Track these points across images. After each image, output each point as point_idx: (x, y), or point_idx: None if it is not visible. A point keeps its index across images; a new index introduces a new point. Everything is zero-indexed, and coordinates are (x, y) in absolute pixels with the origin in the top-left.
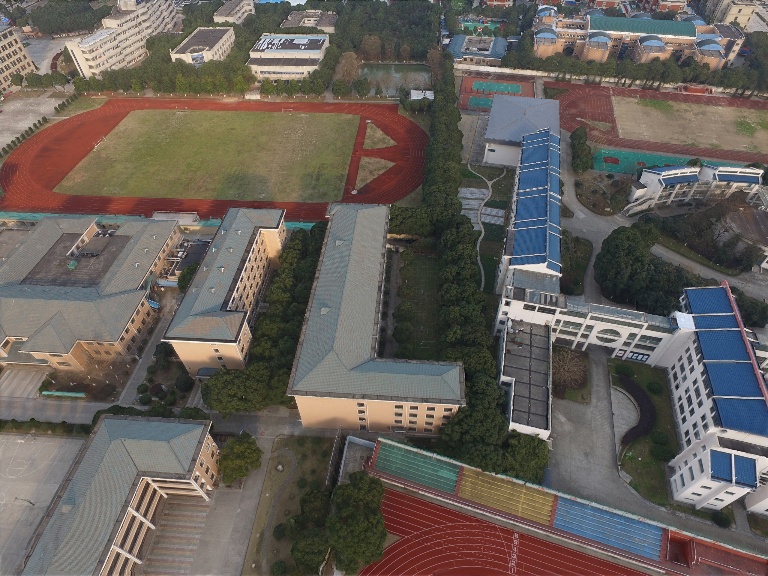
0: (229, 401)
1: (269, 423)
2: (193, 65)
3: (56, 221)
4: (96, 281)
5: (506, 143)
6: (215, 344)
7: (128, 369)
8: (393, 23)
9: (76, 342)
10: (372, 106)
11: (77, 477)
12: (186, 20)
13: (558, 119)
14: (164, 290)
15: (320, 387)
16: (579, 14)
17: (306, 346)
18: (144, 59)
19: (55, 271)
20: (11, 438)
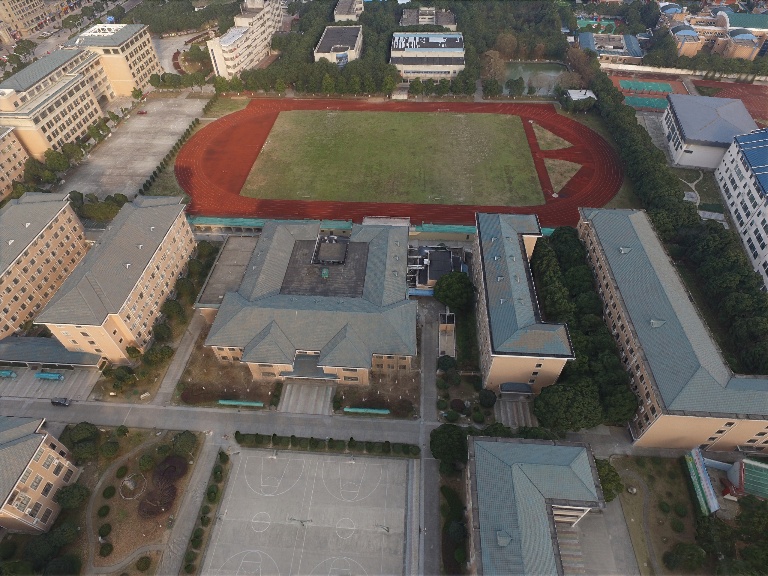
0: (578, 420)
1: (594, 442)
2: (337, 64)
3: (286, 227)
4: (358, 290)
5: (710, 144)
6: (543, 359)
7: (414, 383)
8: (509, 21)
9: (373, 356)
10: (527, 106)
11: (486, 505)
12: (305, 18)
13: (752, 119)
14: (409, 299)
15: (697, 406)
16: (701, 11)
17: (655, 361)
18: (266, 58)
19: (308, 280)
20: (328, 458)
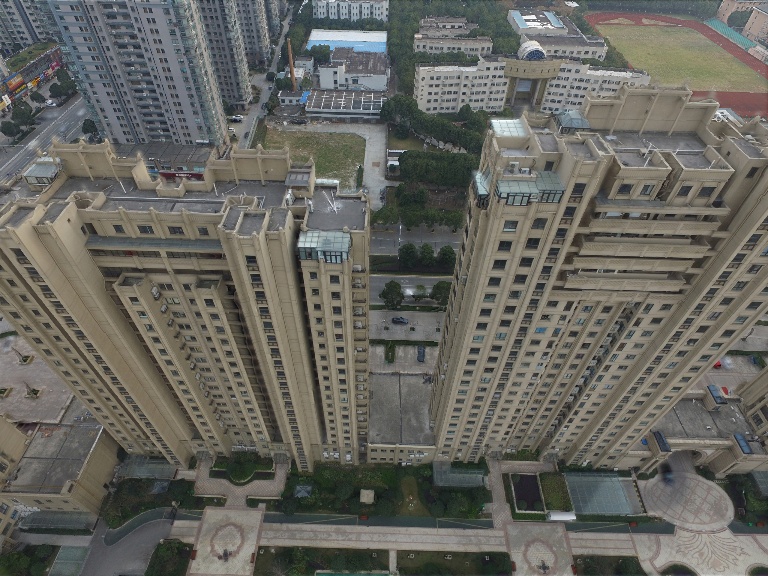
0: None
1: None
2: None
3: None
4: None
5: None
6: None
7: None
8: None
9: None
10: None
11: None
12: None
13: None
14: None
15: None
16: None
17: None
18: None
19: None
20: None
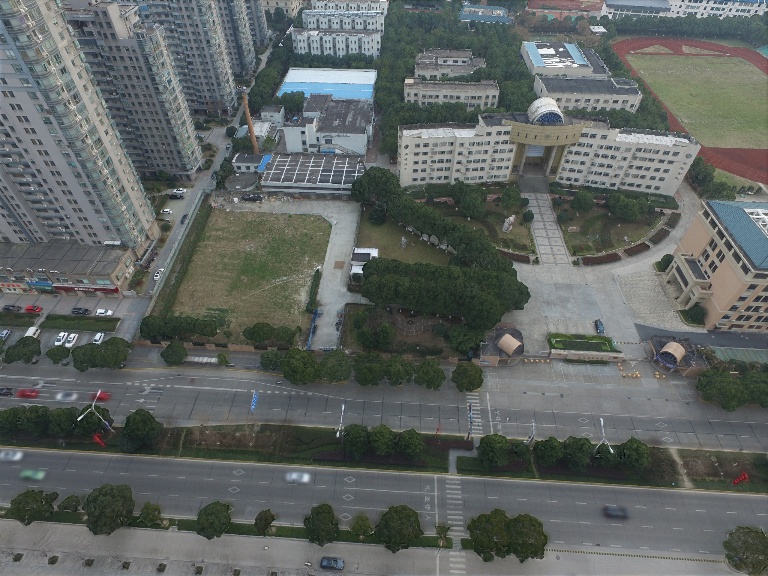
0: None
1: None
2: None
3: None
4: None
5: None
6: None
7: None
8: None
9: None
10: None
11: None
12: None
13: None
14: None
15: None
16: None
17: None
18: None
19: None
20: None
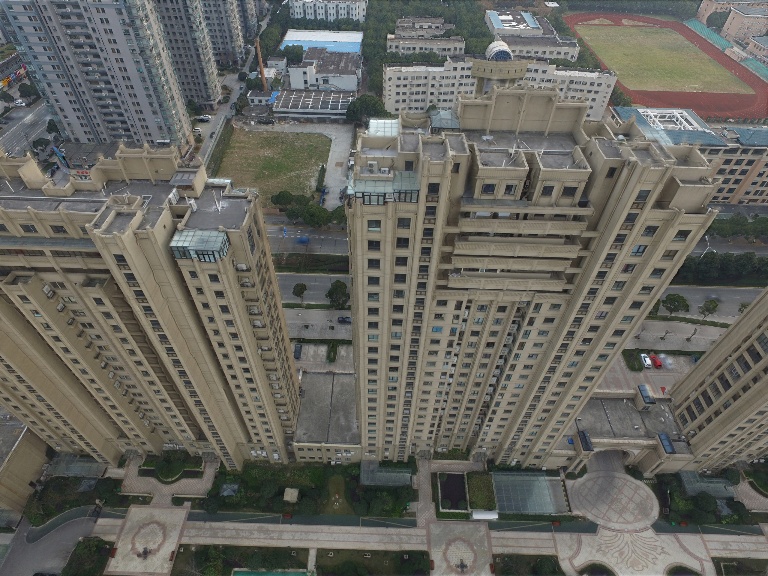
0: None
1: None
2: None
3: None
4: None
5: None
6: None
7: None
8: None
9: None
10: None
11: None
12: None
13: None
14: None
15: None
16: None
17: None
18: None
19: None
20: None
